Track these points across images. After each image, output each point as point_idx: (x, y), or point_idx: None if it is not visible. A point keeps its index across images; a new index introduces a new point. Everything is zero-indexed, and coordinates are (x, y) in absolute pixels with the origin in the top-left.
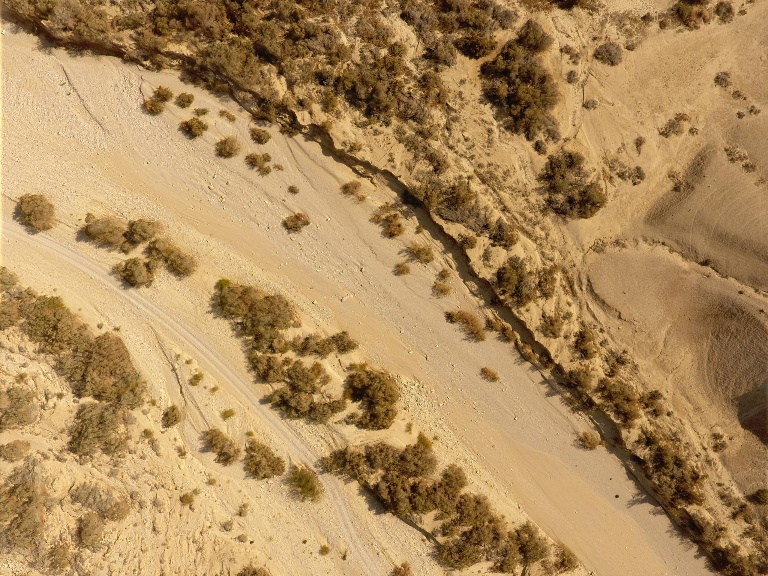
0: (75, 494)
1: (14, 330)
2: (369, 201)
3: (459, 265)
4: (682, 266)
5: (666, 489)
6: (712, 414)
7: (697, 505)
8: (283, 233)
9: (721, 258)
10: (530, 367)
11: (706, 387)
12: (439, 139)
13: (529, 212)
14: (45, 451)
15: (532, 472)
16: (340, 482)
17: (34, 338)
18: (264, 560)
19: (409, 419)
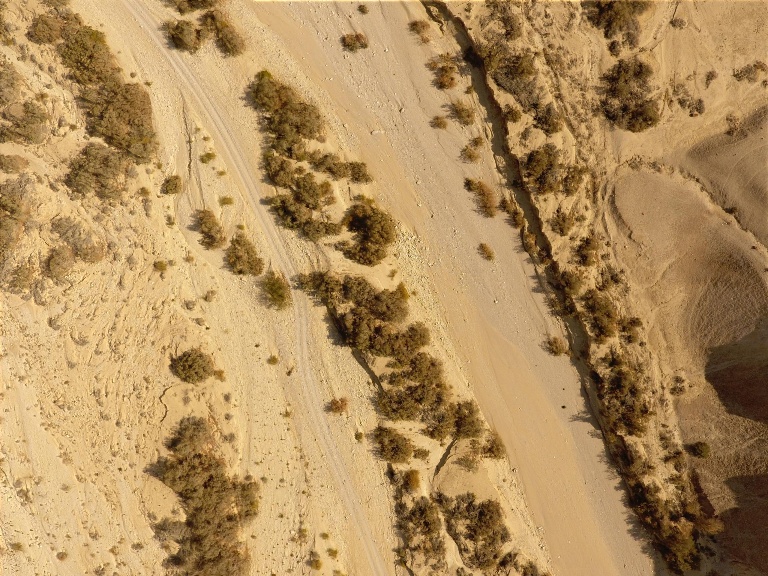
0: (57, 223)
1: (50, 48)
2: (432, 46)
3: (495, 137)
4: (707, 206)
5: (613, 412)
6: (682, 357)
7: (636, 436)
8: (339, 48)
9: (748, 209)
10: (527, 258)
11: (686, 329)
12: (521, 6)
13: (581, 107)
14: (41, 175)
15: (493, 357)
16: (310, 302)
17: (67, 61)
18: (213, 349)
19: (396, 266)
